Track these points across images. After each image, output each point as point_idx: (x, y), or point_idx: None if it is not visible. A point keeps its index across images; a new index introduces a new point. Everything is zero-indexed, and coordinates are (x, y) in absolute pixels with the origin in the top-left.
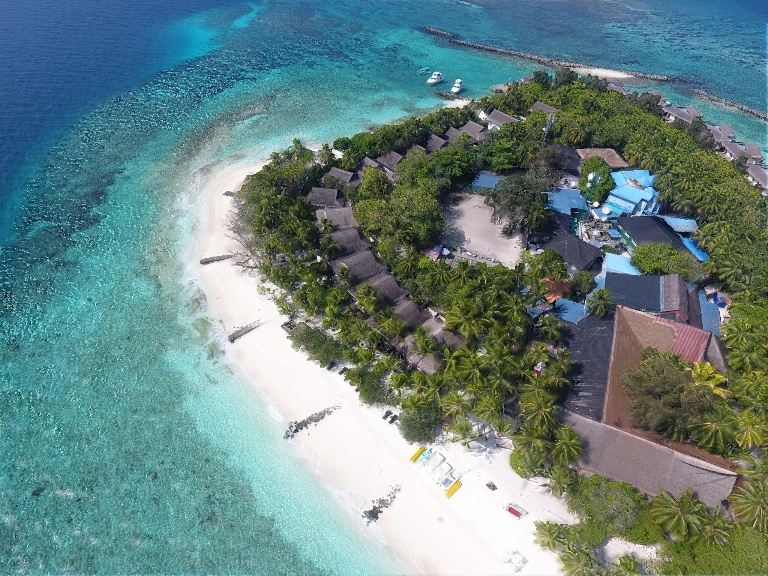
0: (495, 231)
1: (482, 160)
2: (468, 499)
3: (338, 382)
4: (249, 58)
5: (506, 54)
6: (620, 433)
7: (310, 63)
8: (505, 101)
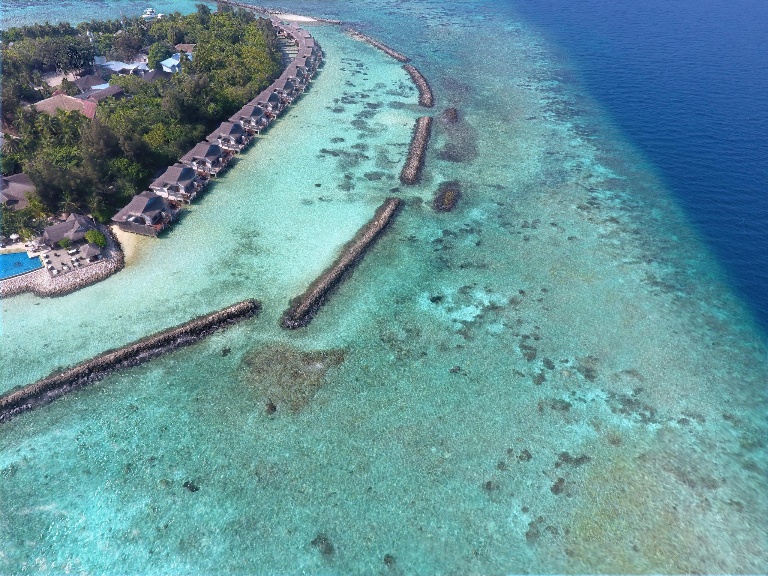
0: None
1: None
2: None
3: None
4: None
5: (236, 5)
6: None
7: (66, 4)
8: (162, 21)
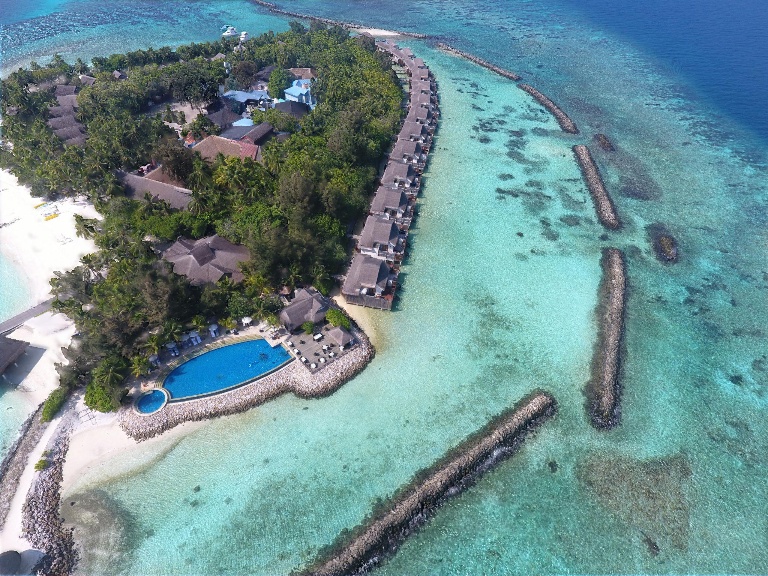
0: (193, 115)
1: (207, 74)
2: (58, 221)
3: (13, 179)
4: (84, 18)
5: (309, 19)
6: (150, 181)
7: (135, 22)
8: None
